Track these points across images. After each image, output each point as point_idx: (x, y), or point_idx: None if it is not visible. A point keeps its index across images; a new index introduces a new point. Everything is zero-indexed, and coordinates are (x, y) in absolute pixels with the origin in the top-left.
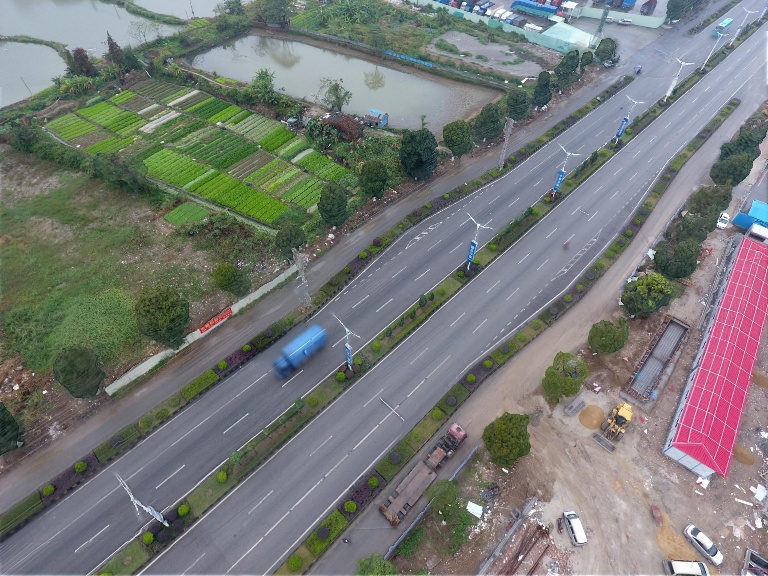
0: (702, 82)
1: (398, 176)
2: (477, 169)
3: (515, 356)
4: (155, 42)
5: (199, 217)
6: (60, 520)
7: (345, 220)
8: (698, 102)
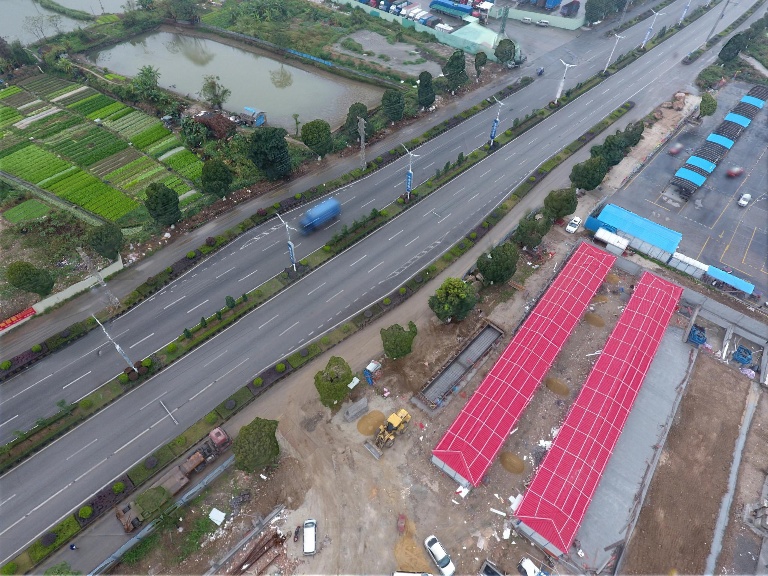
0: (602, 84)
1: (256, 175)
2: (342, 169)
3: (315, 360)
4: (55, 37)
5: (39, 214)
6: None
7: (185, 219)
8: (592, 104)
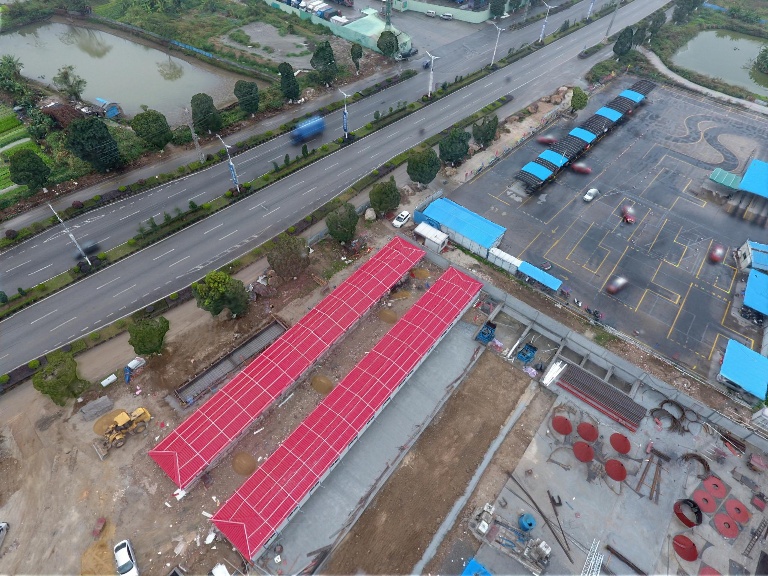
0: (487, 78)
1: (86, 167)
2: (182, 162)
3: (78, 356)
4: None
5: None
6: None
7: None
8: (468, 98)
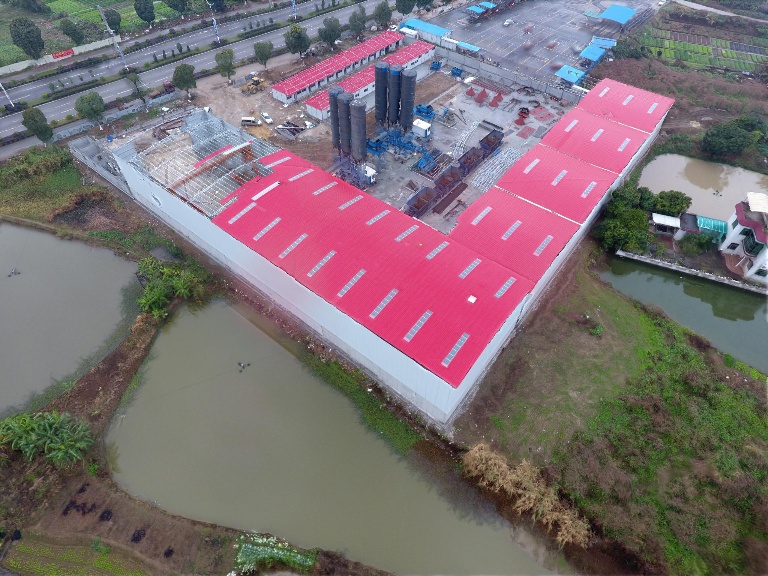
0: None
1: (203, 8)
2: None
3: None
4: None
5: None
6: None
7: None
8: None
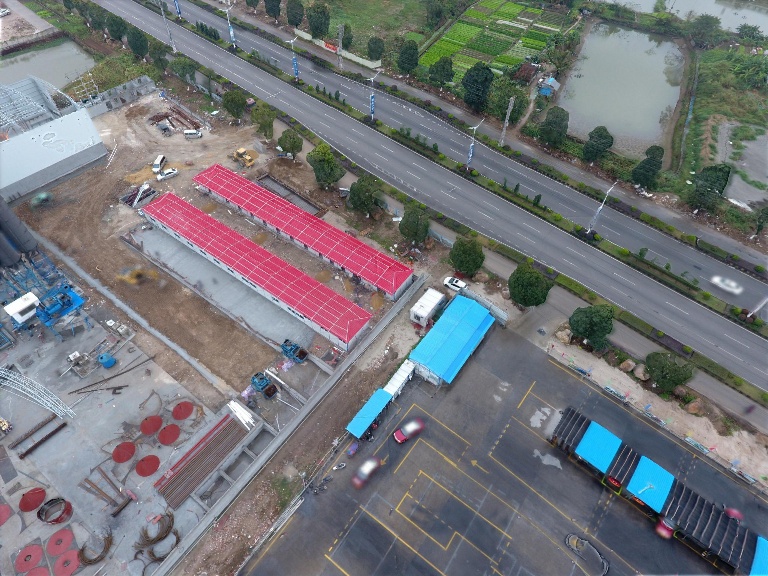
0: None
1: None
2: (499, 137)
3: (300, 135)
4: (610, 5)
5: None
6: (245, 34)
7: None
8: None
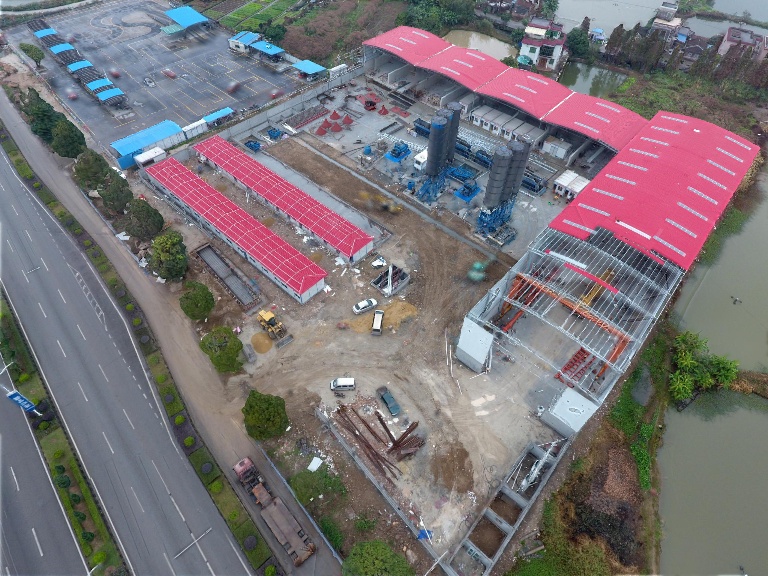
0: None
1: None
2: None
3: (180, 391)
4: None
5: None
6: None
7: None
8: None
